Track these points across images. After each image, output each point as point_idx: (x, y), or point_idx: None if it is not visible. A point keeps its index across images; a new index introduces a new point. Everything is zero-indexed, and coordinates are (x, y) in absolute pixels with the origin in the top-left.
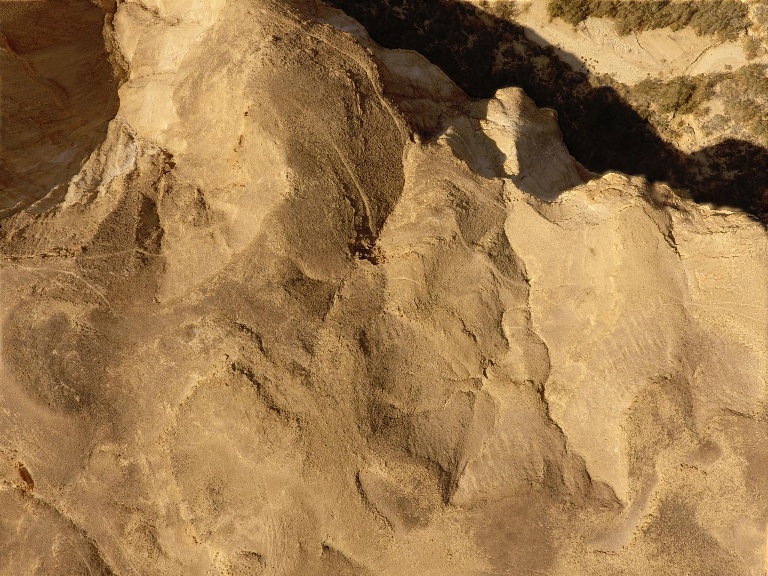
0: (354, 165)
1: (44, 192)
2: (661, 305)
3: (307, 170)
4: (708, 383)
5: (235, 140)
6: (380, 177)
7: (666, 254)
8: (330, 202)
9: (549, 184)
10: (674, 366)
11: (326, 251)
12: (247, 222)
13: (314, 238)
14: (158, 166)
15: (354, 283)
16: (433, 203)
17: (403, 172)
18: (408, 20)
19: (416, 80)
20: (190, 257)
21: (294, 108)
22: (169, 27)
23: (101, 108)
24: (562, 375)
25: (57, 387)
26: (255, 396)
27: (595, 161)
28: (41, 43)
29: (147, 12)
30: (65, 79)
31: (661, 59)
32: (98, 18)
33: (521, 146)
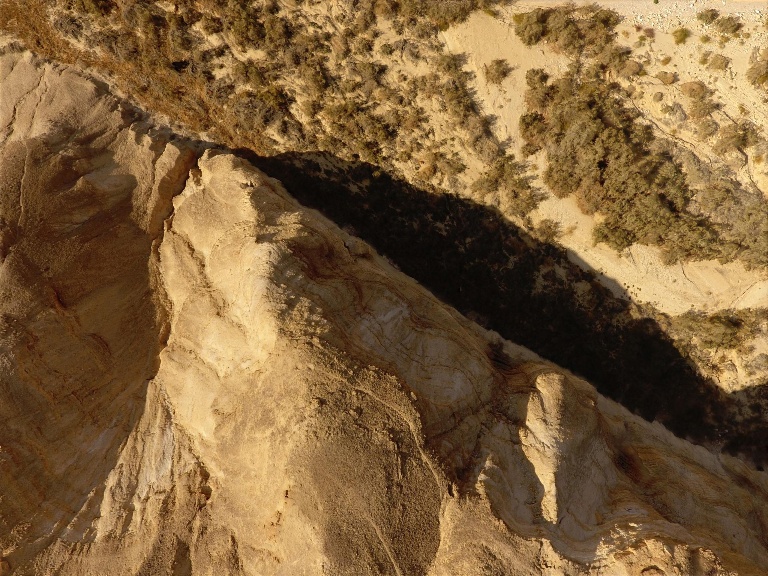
0: (391, 539)
1: (81, 499)
2: None
3: (343, 558)
4: None
5: (273, 512)
6: (416, 543)
7: None
8: None
9: (586, 512)
10: None
11: None
12: None
13: None
14: (194, 495)
15: None
16: None
17: (439, 530)
18: (450, 237)
19: (458, 401)
20: None
21: (335, 487)
22: (215, 318)
23: (142, 364)
24: None
25: None
26: None
27: (631, 393)
28: (89, 287)
29: (194, 263)
30: (109, 330)
31: (707, 291)
32: (145, 246)
33: (560, 476)
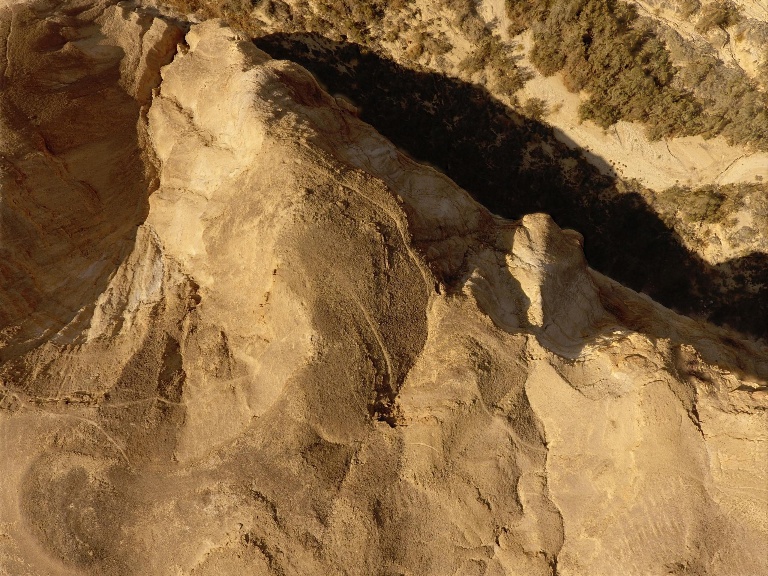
0: (378, 323)
1: (71, 314)
2: (681, 486)
3: (332, 332)
4: (725, 571)
5: (262, 294)
6: (403, 332)
7: (689, 432)
8: (352, 364)
9: (572, 328)
10: (691, 552)
11: (345, 415)
12: (269, 382)
13: (334, 403)
14: (184, 301)
15: (371, 446)
16: (455, 363)
17: (426, 325)
18: (438, 115)
19: (444, 219)
20: (210, 412)
21: (322, 267)
22: (203, 148)
23: (131, 211)
24: (576, 548)
25: (72, 540)
26: (266, 569)
27: (618, 267)
28: (77, 141)
29: (182, 116)
30: (98, 180)
31: (691, 167)
32: (133, 111)
33: (546, 290)
